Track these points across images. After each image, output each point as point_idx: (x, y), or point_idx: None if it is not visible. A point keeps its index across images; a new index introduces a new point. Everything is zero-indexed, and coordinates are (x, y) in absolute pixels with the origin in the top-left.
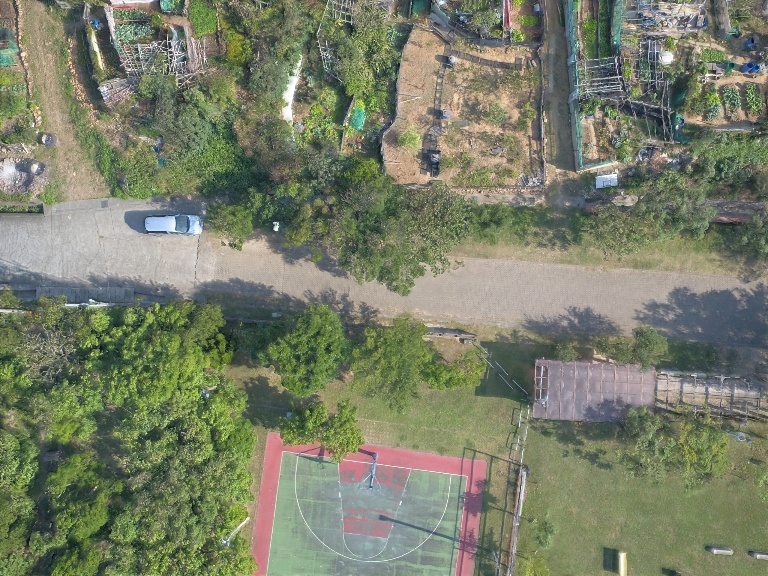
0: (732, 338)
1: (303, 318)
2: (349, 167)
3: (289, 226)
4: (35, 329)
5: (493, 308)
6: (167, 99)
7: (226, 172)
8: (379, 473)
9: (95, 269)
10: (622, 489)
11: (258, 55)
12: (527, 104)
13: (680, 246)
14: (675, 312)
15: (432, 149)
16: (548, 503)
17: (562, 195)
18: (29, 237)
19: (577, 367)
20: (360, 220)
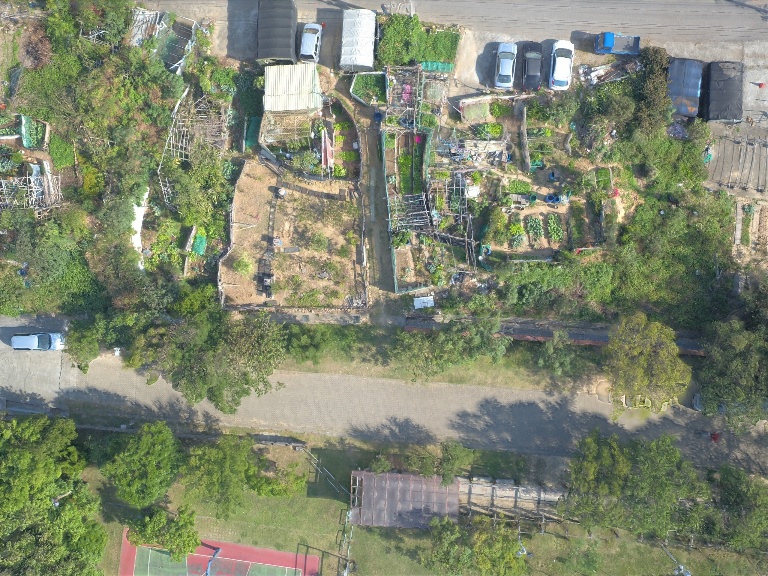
0: (539, 447)
1: (134, 439)
2: (178, 300)
3: None
4: None
5: (322, 418)
6: (24, 233)
7: (83, 294)
8: (222, 566)
9: None
10: None
11: (110, 188)
12: (350, 232)
13: None
14: (487, 423)
15: (267, 273)
16: None
17: (385, 314)
18: None
19: (388, 478)
20: (185, 350)
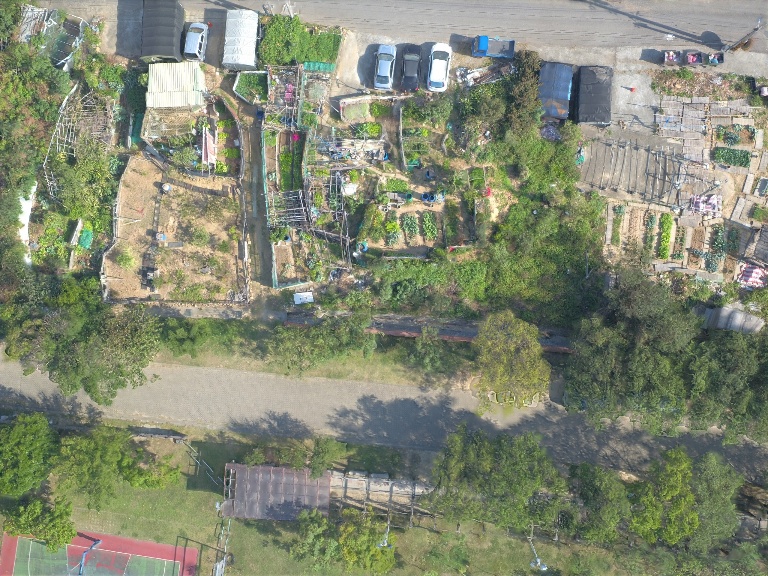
0: (414, 442)
1: (6, 429)
2: (55, 291)
3: None
4: None
5: (203, 411)
6: None
7: None
8: (102, 558)
9: None
10: None
11: None
12: (232, 228)
13: None
14: (363, 417)
15: (151, 267)
16: None
17: (266, 309)
18: None
19: (261, 470)
20: (59, 341)
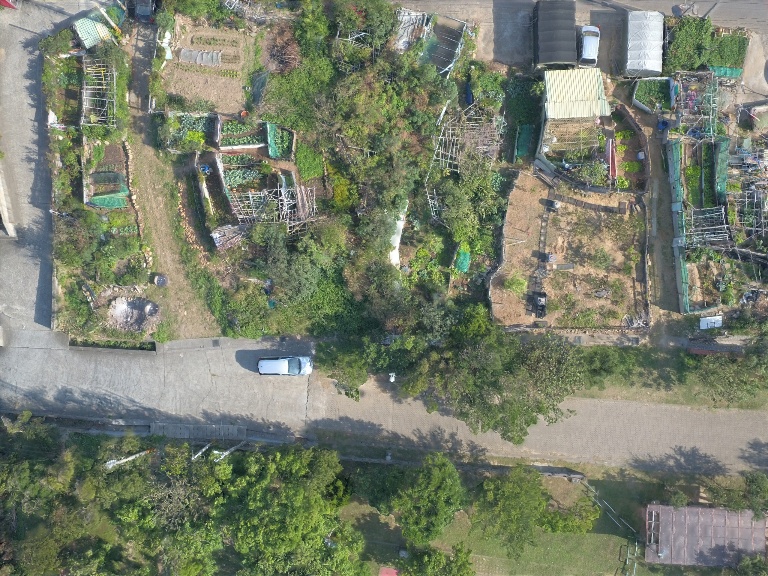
0: None
1: (424, 473)
2: (464, 321)
3: (402, 373)
4: (151, 466)
5: (600, 447)
6: (281, 249)
7: (336, 314)
8: None
9: (208, 407)
10: None
11: (365, 200)
12: (632, 248)
13: None
14: None
15: (537, 291)
16: None
17: (666, 335)
18: (142, 374)
19: (688, 512)
20: (478, 376)
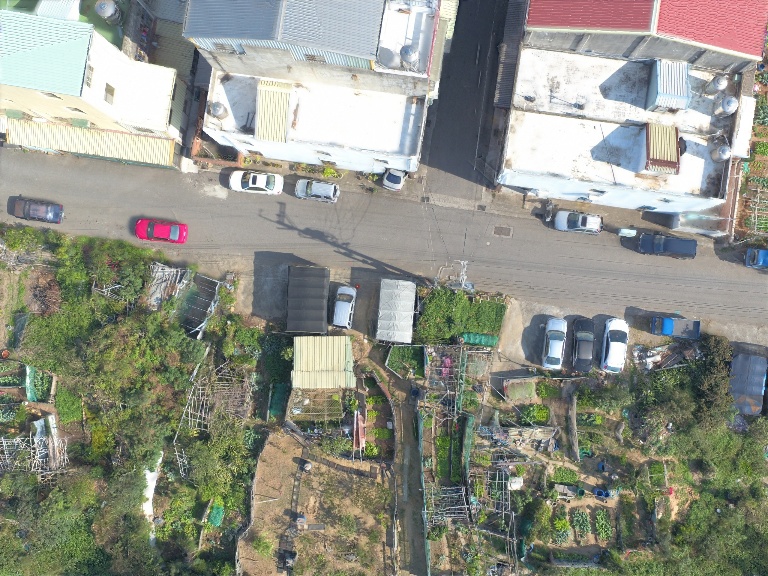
0: None
1: None
2: None
3: None
4: None
5: None
6: (26, 505)
7: (88, 563)
8: None
9: None
10: None
11: (120, 450)
12: (381, 514)
13: None
14: None
15: (288, 550)
16: None
17: None
18: None
19: None
20: None
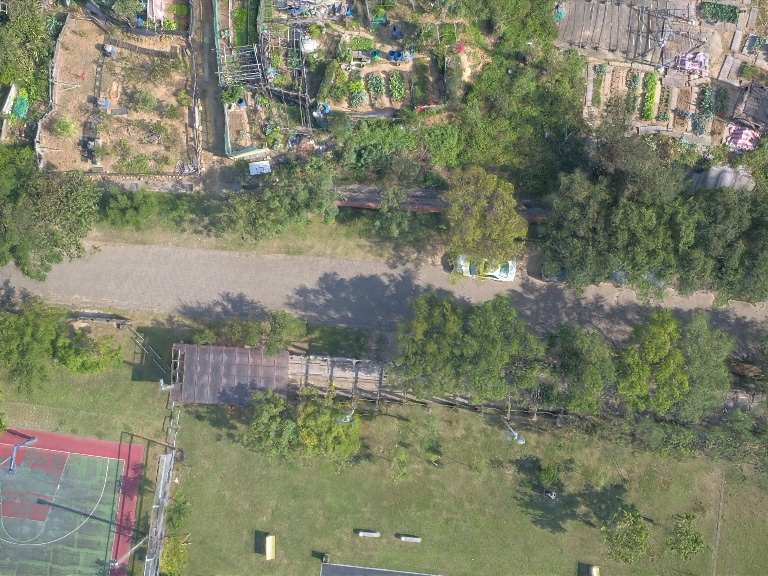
0: (380, 322)
1: None
2: None
3: None
4: None
5: (149, 293)
6: None
7: None
8: (38, 457)
9: None
10: (273, 472)
11: None
12: (181, 92)
13: (331, 232)
14: (325, 297)
15: (92, 136)
16: (202, 486)
17: (219, 182)
18: None
19: (212, 350)
20: None
